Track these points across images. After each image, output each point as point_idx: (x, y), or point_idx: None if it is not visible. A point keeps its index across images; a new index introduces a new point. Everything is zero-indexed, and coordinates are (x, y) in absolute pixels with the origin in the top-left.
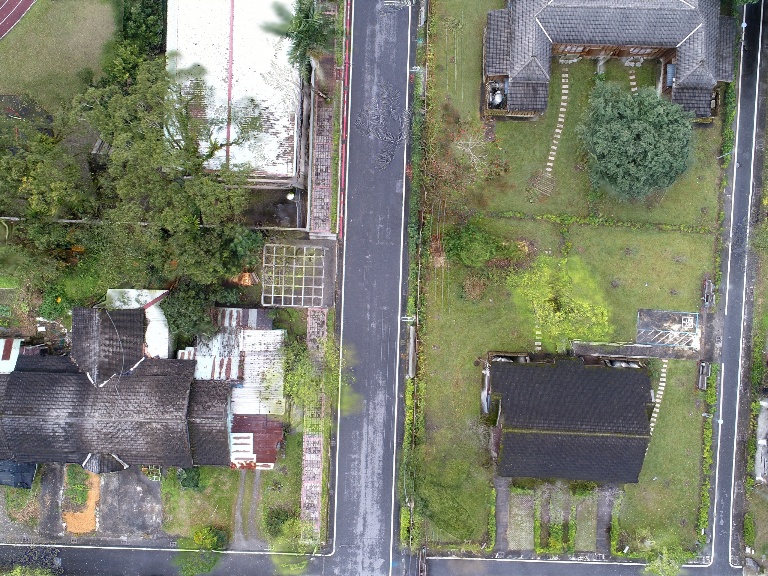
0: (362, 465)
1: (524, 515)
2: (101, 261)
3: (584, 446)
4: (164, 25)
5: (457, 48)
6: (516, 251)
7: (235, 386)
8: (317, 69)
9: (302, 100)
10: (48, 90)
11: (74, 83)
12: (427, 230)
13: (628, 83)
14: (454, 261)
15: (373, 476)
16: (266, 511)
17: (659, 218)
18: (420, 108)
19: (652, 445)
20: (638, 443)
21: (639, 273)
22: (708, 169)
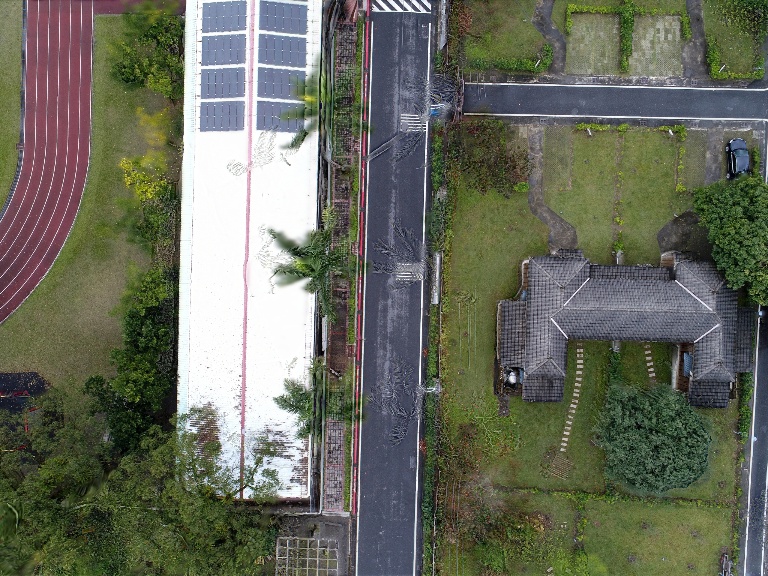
0: None
1: None
2: (112, 539)
3: None
4: (175, 341)
5: (470, 322)
6: (531, 532)
7: None
8: (329, 347)
9: (315, 398)
10: (57, 367)
11: (83, 360)
12: (441, 512)
13: (644, 358)
14: None
15: None
16: None
17: (676, 492)
18: None
19: None
20: None
21: (656, 548)
22: (725, 443)
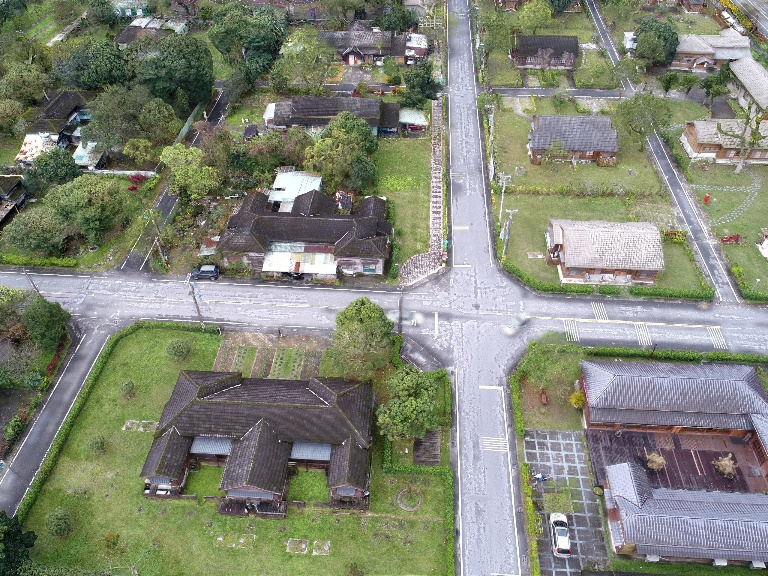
0: None
1: (534, 79)
2: None
3: (551, 41)
4: None
5: None
6: (515, 27)
7: (407, 41)
8: (435, 3)
9: None
10: None
11: (348, 6)
12: (480, 23)
13: None
14: None
15: (465, 70)
16: None
17: None
18: (473, 6)
19: None
20: (573, 39)
21: None
22: None
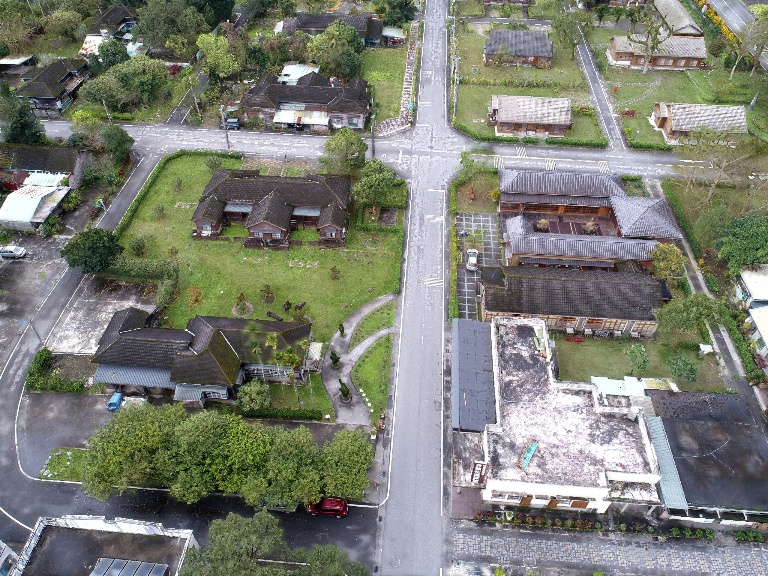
0: None
1: None
2: None
3: None
4: None
5: None
6: None
7: None
8: None
9: None
10: None
11: None
12: None
13: None
14: None
15: None
16: None
17: None
18: None
19: None
20: None
21: None
22: None
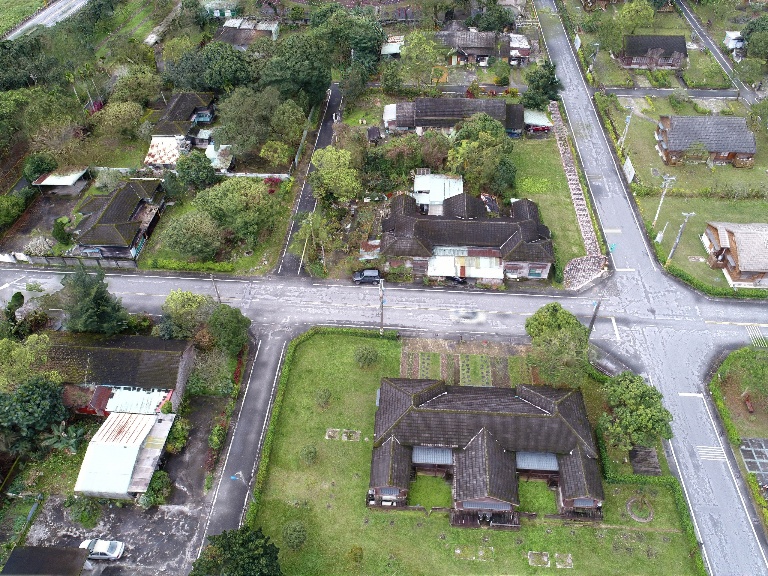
0: (564, 68)
1: (643, 79)
2: None
3: (659, 40)
4: None
5: (571, 2)
6: None
7: None
8: None
9: None
10: None
11: (434, 6)
12: None
13: None
14: (587, 31)
15: (570, 70)
16: (524, 77)
17: None
18: None
19: (691, 65)
20: (681, 39)
21: None
22: None
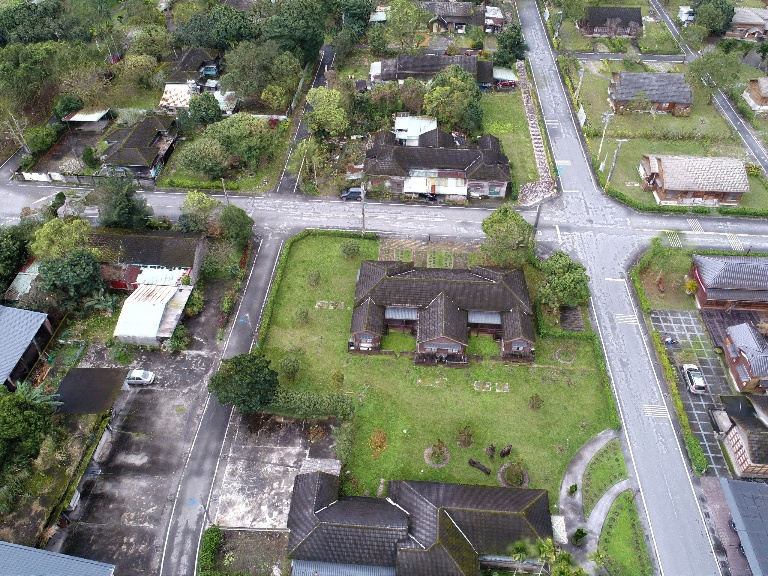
0: None
1: None
2: None
3: (618, 12)
4: None
5: None
6: None
7: None
8: None
9: None
10: None
11: None
12: None
13: None
14: (556, 5)
15: None
16: None
17: None
18: None
19: (647, 35)
20: (637, 10)
21: None
22: None
